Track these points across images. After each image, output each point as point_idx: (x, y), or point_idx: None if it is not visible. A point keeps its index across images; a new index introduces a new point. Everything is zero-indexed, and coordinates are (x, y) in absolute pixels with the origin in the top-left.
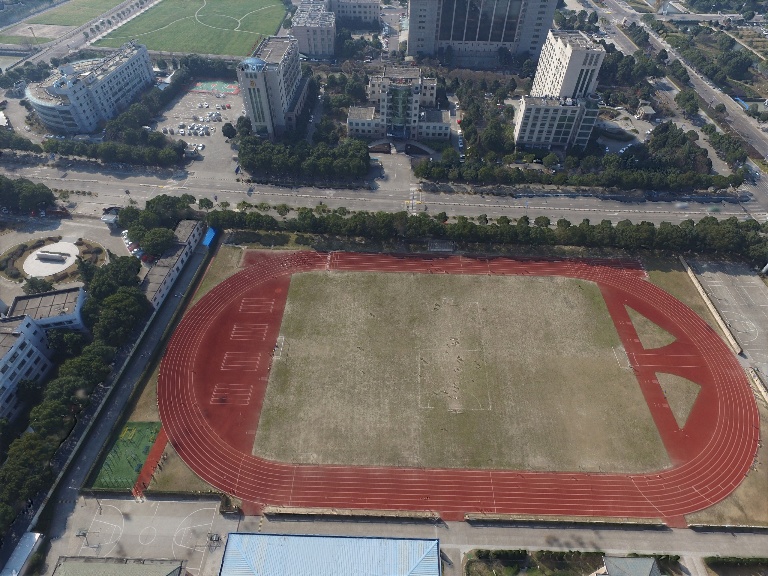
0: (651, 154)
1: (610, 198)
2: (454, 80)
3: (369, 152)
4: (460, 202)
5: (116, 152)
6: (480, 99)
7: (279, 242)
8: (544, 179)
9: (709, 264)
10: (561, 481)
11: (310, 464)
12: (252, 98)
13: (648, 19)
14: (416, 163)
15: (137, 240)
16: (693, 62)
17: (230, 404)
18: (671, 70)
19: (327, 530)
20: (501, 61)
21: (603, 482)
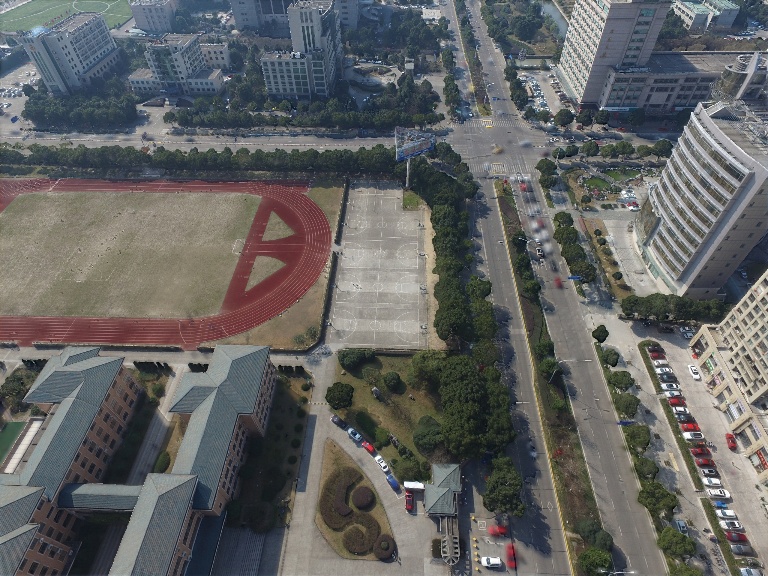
0: None
1: (326, 136)
2: (252, 46)
3: (146, 106)
4: (195, 141)
5: None
6: None
7: (24, 173)
8: (269, 121)
9: (368, 182)
10: (125, 323)
11: None
12: (37, 61)
13: None
14: (173, 112)
15: None
16: (488, 26)
17: None
18: (464, 34)
19: None
20: None
21: (156, 324)
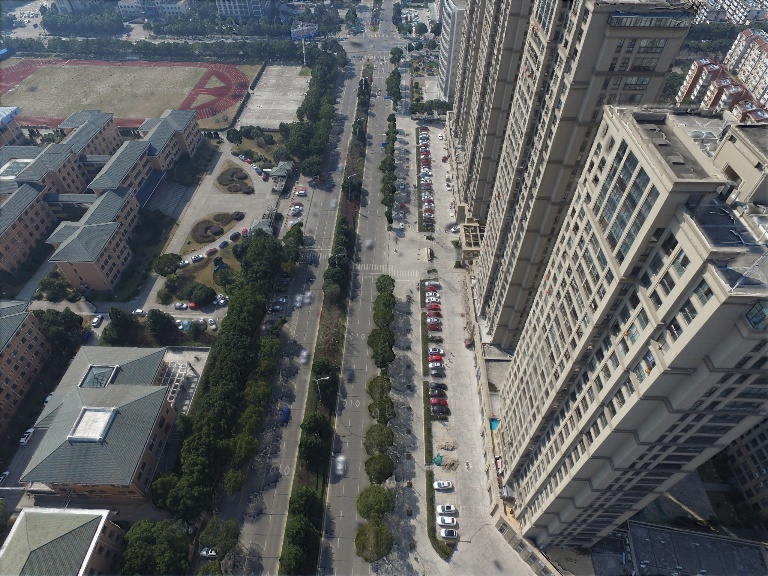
0: None
1: None
2: None
3: (130, 23)
4: None
5: None
6: None
7: (44, 56)
8: (217, 29)
9: (280, 63)
10: (114, 120)
11: None
12: None
13: None
14: None
15: None
16: None
17: None
18: None
19: None
20: None
21: (133, 120)
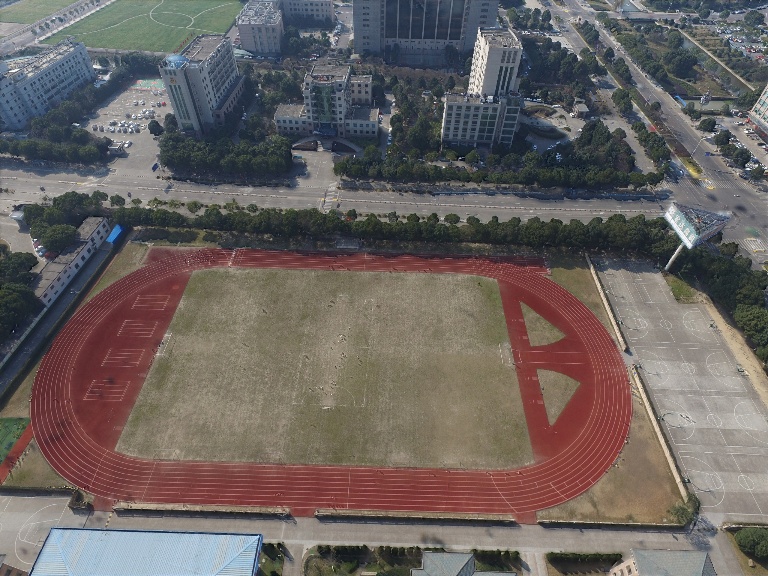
0: (576, 152)
1: (528, 196)
2: (392, 78)
3: (295, 149)
4: (377, 199)
5: (37, 149)
6: (416, 97)
7: (186, 239)
8: (462, 176)
9: (614, 261)
10: (419, 477)
11: (171, 460)
12: (174, 95)
13: (602, 17)
14: (338, 160)
15: (38, 237)
16: (638, 60)
17: (103, 400)
18: (615, 68)
19: (174, 526)
20: (447, 59)
21: (461, 478)
